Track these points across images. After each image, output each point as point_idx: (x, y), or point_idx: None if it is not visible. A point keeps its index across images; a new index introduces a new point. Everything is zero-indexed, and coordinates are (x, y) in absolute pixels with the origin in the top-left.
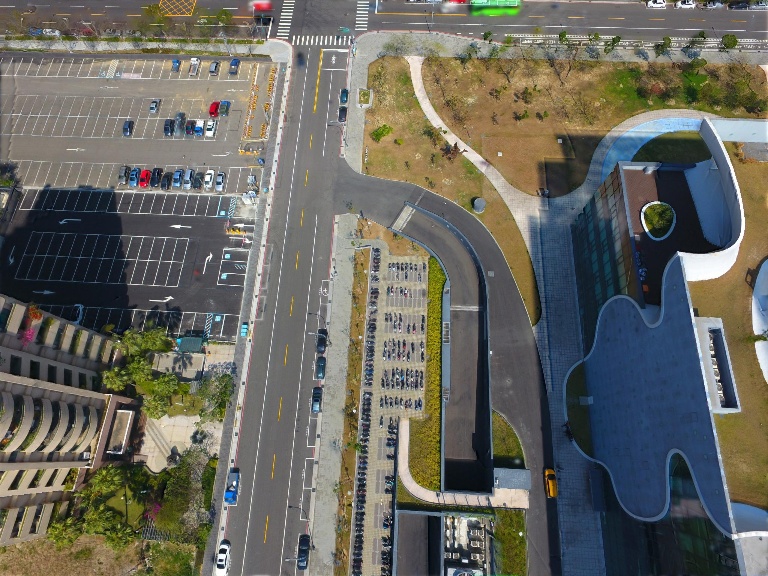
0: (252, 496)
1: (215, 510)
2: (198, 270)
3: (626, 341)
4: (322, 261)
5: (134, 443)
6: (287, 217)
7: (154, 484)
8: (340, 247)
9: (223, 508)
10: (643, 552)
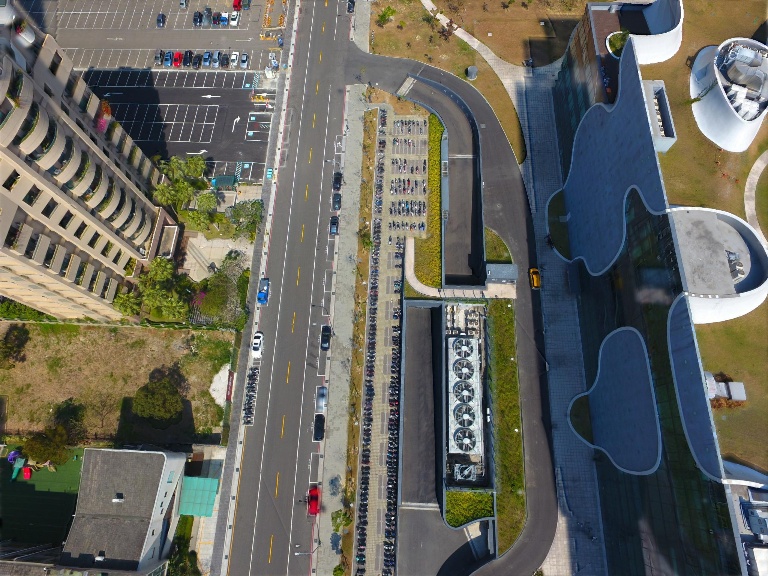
0: (281, 298)
1: (249, 309)
2: (228, 129)
3: (594, 140)
4: (336, 121)
5: (178, 260)
6: (304, 87)
7: (197, 288)
8: (351, 110)
9: (256, 308)
10: (608, 294)
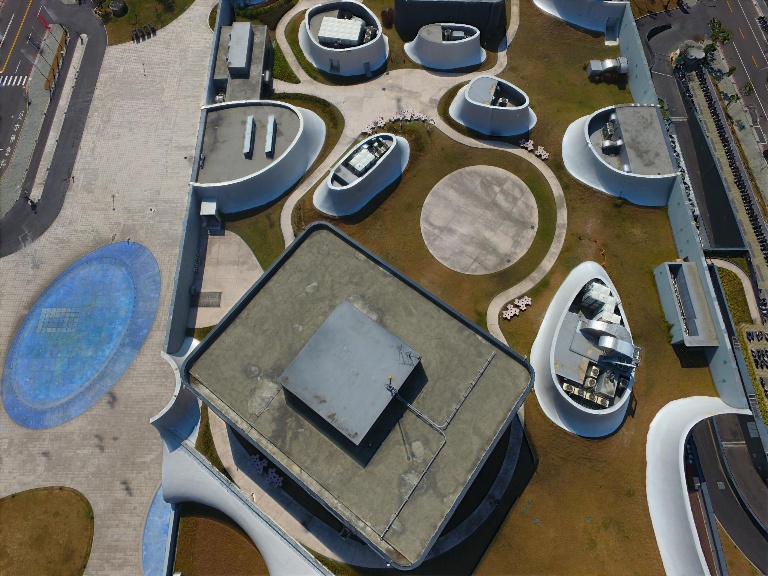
0: None
1: None
2: None
3: None
4: None
5: None
6: None
7: None
8: None
9: None
10: None
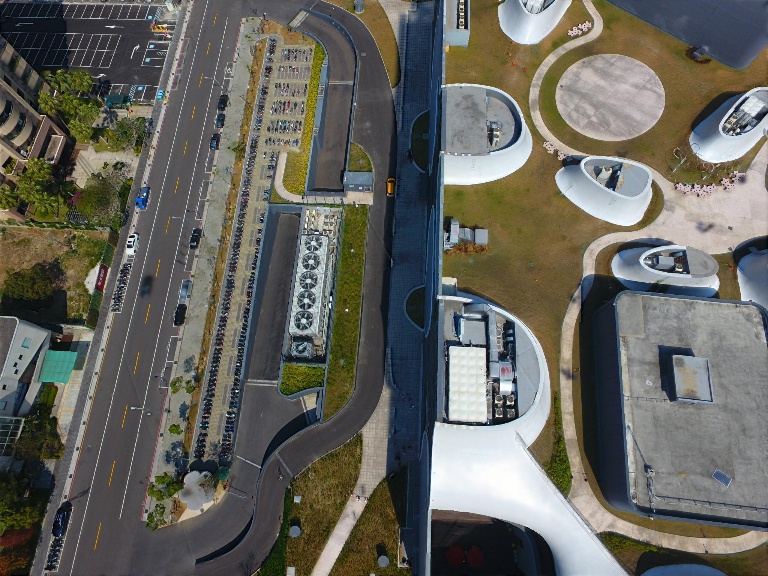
0: (158, 204)
1: (129, 214)
2: (127, 56)
3: None
4: (229, 49)
5: (67, 169)
6: (203, 19)
7: None
8: (244, 40)
9: (135, 213)
10: None
